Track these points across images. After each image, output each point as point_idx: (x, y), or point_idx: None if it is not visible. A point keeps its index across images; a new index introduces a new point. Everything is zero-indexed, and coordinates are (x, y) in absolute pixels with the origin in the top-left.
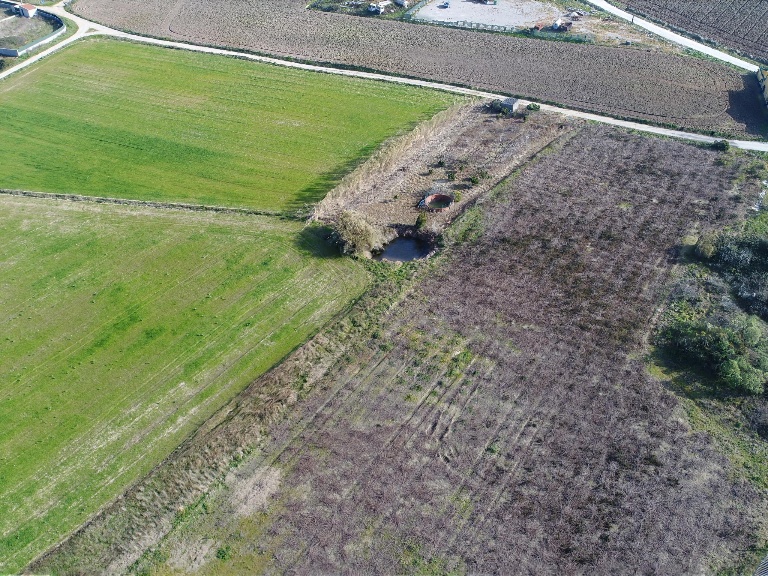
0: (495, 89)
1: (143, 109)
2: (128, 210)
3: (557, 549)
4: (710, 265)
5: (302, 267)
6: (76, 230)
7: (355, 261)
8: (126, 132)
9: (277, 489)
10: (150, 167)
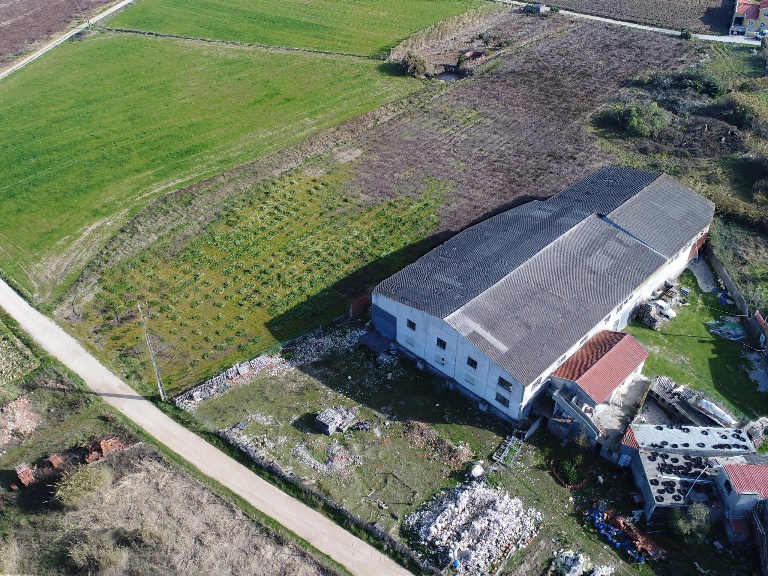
0: (530, 1)
1: (275, 3)
2: (269, 50)
3: (508, 181)
4: (645, 87)
5: (381, 79)
6: (238, 57)
7: (415, 78)
8: (264, 14)
9: (360, 156)
10: (282, 31)
